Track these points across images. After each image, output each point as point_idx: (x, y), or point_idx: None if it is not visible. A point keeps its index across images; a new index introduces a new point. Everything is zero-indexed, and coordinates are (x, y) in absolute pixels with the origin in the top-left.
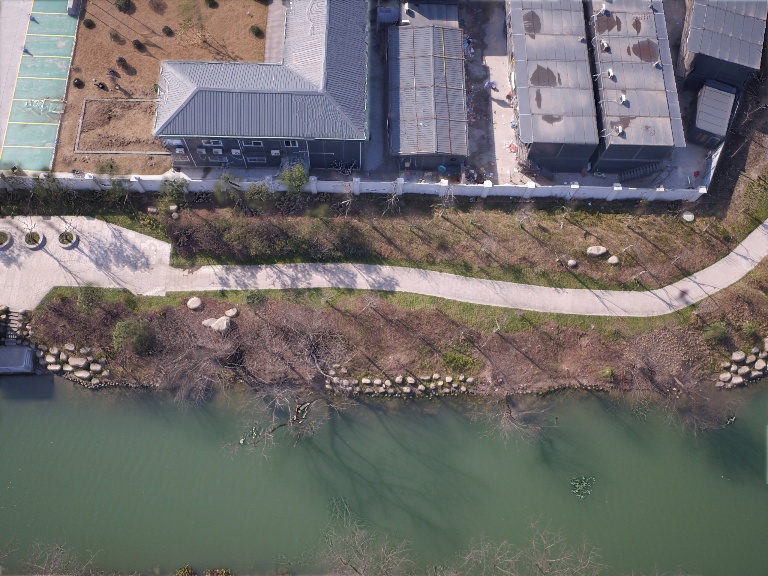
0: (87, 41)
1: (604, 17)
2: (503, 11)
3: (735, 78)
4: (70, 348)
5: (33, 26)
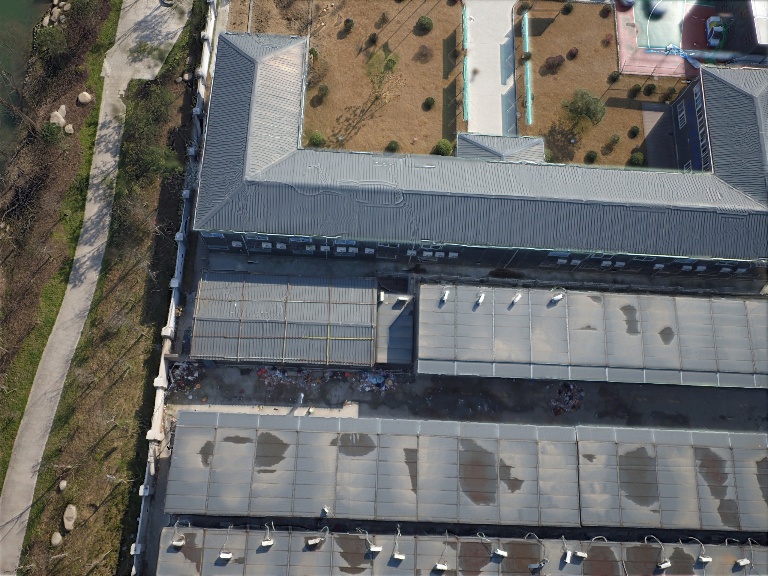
0: None
1: (364, 549)
2: None
3: None
4: (65, 7)
5: None
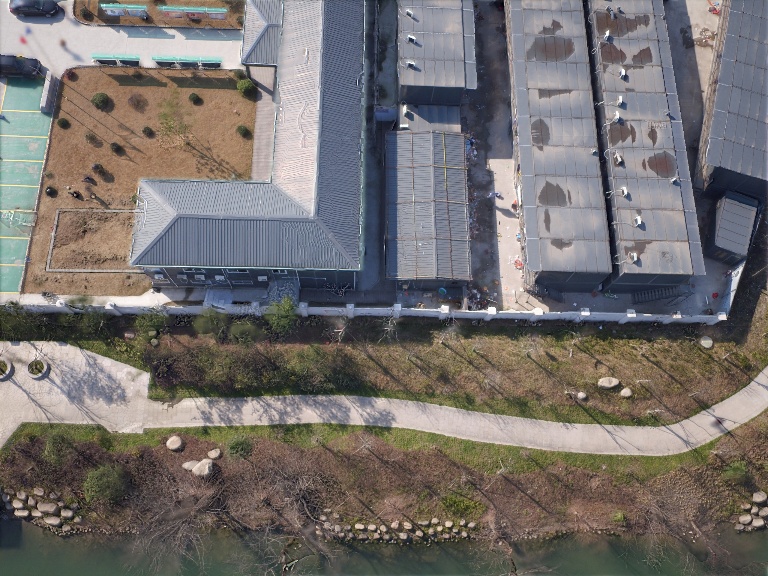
0: (61, 143)
1: (617, 126)
2: (508, 108)
3: (757, 191)
4: (39, 493)
5: (3, 126)
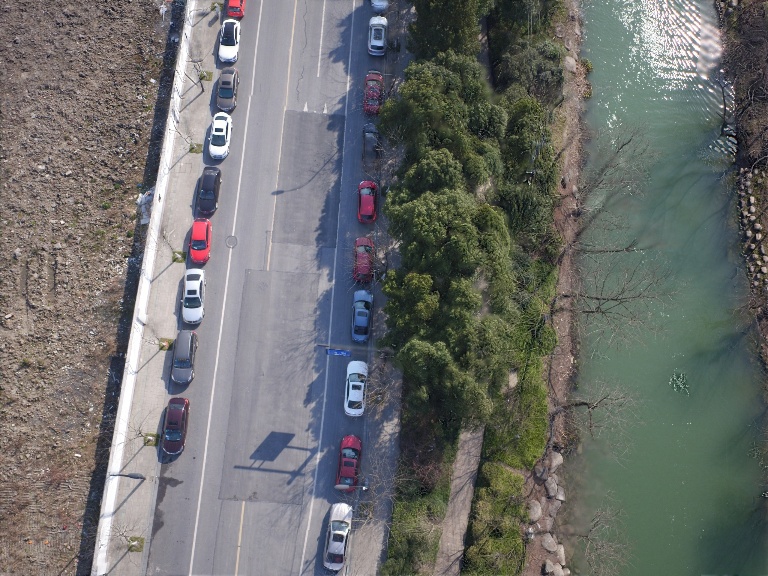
0: None
1: None
2: None
3: None
4: None
5: None
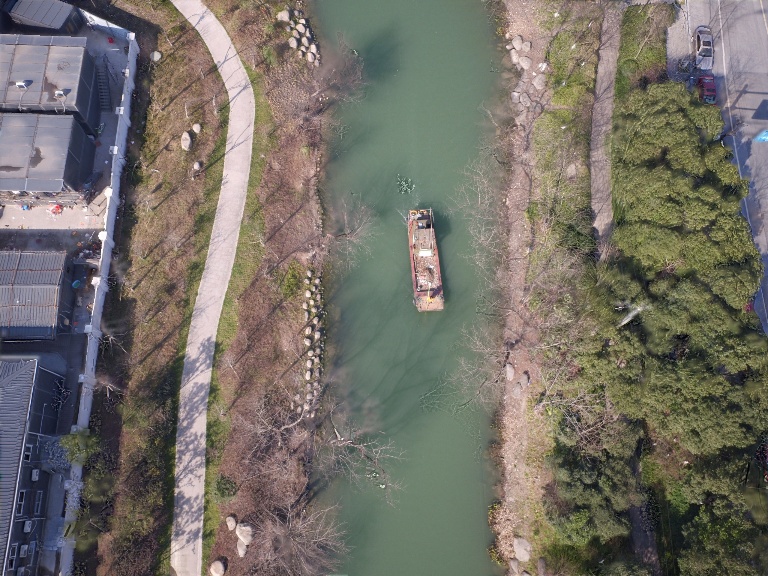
0: None
1: None
2: None
3: None
4: None
5: None
